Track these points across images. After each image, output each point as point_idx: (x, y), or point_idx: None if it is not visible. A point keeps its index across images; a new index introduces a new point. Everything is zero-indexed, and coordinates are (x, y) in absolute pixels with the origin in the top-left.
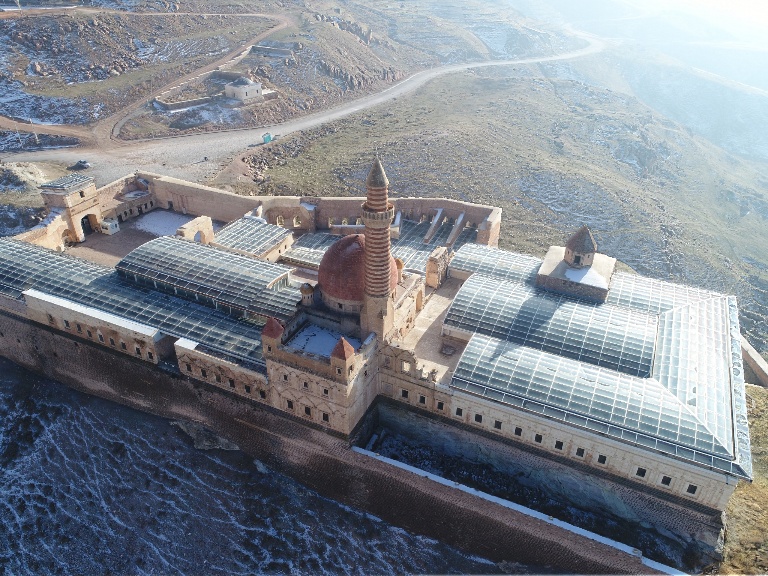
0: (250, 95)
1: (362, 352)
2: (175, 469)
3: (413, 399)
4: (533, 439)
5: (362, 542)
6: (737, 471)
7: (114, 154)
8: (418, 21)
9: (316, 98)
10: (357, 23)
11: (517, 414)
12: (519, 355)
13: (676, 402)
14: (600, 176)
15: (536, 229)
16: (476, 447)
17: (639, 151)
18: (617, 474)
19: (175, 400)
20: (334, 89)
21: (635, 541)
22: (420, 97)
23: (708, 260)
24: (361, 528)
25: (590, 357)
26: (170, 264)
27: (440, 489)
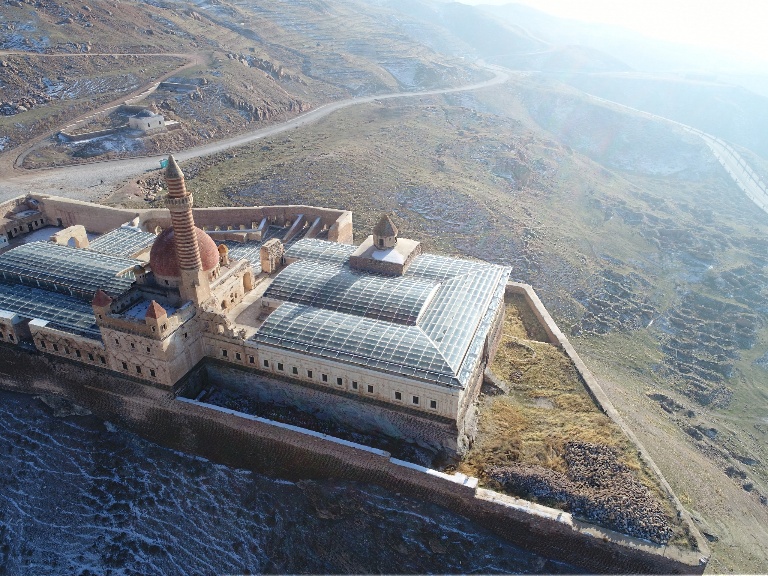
0: (152, 126)
1: (176, 315)
2: (35, 435)
3: (231, 357)
4: (321, 379)
5: (191, 479)
6: (456, 383)
7: (14, 181)
8: (331, 58)
9: (220, 128)
10: (271, 61)
11: (305, 358)
12: (315, 315)
13: (426, 340)
14: (473, 189)
15: (409, 235)
16: (282, 392)
17: (514, 167)
18: (382, 400)
19: (35, 376)
20: (238, 120)
21: (398, 452)
22: (321, 125)
23: (565, 257)
24: (191, 468)
25: (372, 314)
26: (35, 262)
27: (244, 423)
